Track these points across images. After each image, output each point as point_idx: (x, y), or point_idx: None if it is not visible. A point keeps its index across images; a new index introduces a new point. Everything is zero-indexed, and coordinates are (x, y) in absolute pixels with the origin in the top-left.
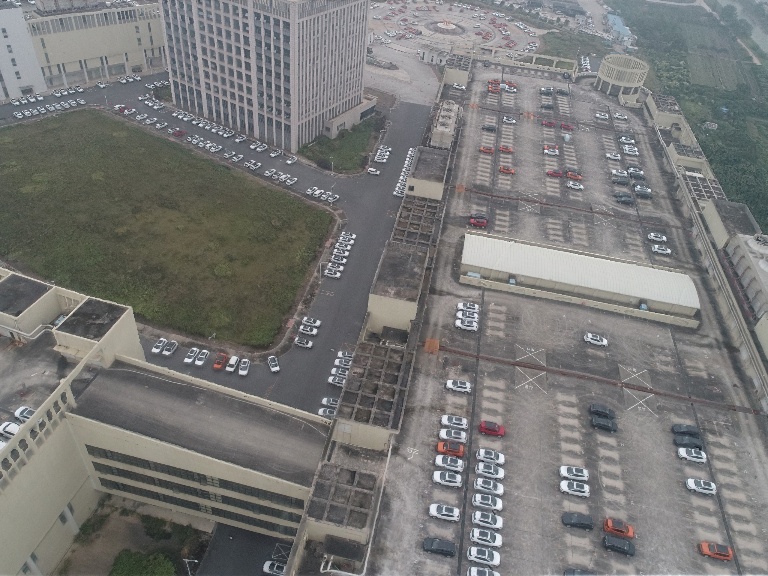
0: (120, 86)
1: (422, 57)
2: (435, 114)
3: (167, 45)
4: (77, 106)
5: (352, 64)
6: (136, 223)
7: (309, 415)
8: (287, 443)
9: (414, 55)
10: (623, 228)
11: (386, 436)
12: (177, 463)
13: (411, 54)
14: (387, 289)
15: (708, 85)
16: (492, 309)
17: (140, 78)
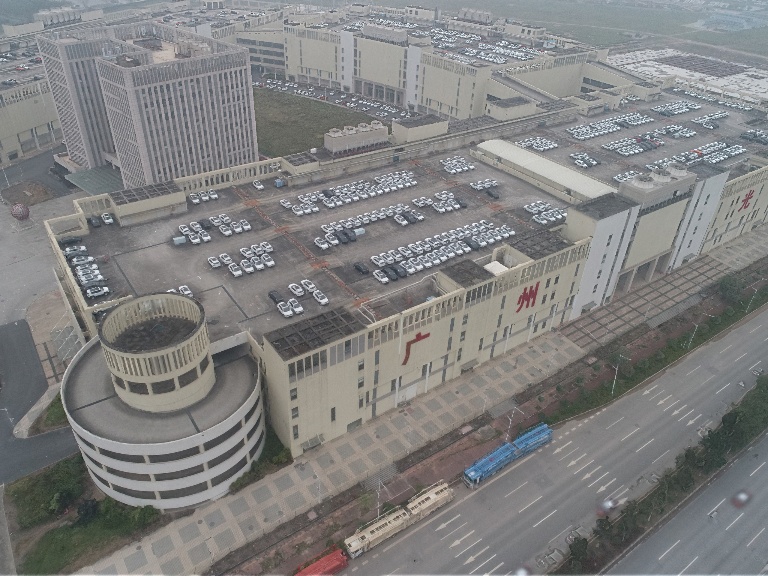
0: None
1: None
2: None
3: None
4: None
5: None
6: None
7: None
8: None
9: None
10: None
11: None
12: None
13: None
14: None
15: None
16: None
17: None
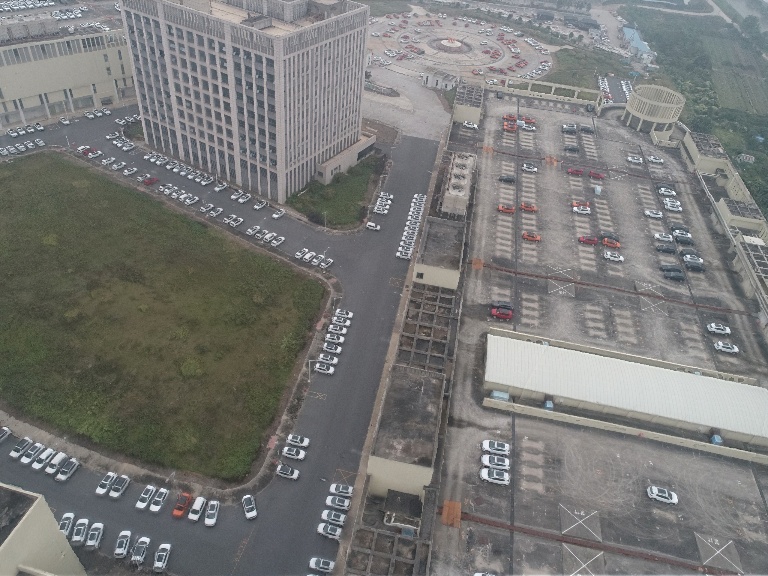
0: (87, 122)
1: (426, 81)
2: (446, 169)
3: (136, 79)
4: (35, 148)
5: (348, 100)
6: (91, 303)
7: None
8: None
9: (417, 78)
10: (676, 315)
11: None
12: None
13: (413, 77)
14: (393, 443)
15: (738, 108)
16: (526, 447)
17: (110, 112)
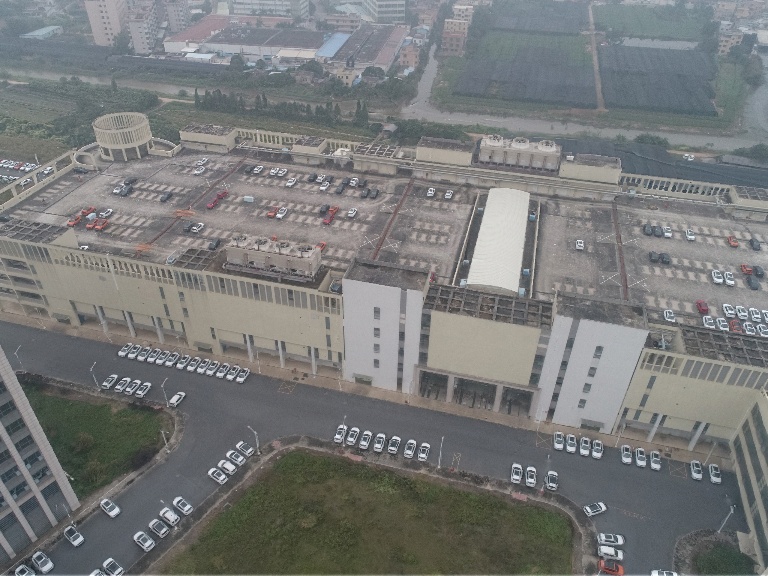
0: None
1: None
2: None
3: None
4: None
5: None
6: None
7: None
8: None
9: None
10: (416, 205)
11: None
12: None
13: None
14: (628, 323)
15: (52, 118)
16: None
17: None
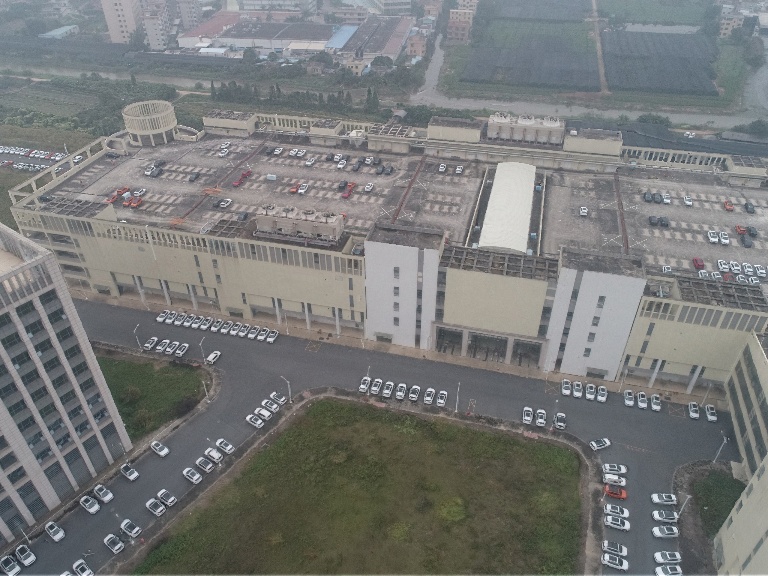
0: None
1: None
2: None
3: None
4: None
5: None
6: None
7: None
8: None
9: None
10: (429, 179)
11: None
12: None
13: None
14: (628, 274)
15: None
16: None
17: None
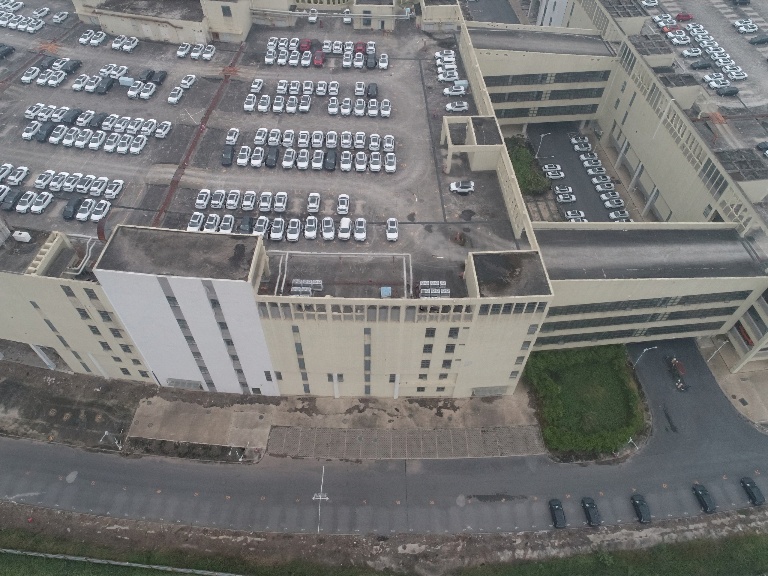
0: None
1: None
2: None
3: None
4: None
5: None
6: None
7: (585, 30)
8: (584, 46)
9: None
10: None
11: (642, 23)
12: (531, 69)
13: None
14: None
15: None
16: None
17: None
